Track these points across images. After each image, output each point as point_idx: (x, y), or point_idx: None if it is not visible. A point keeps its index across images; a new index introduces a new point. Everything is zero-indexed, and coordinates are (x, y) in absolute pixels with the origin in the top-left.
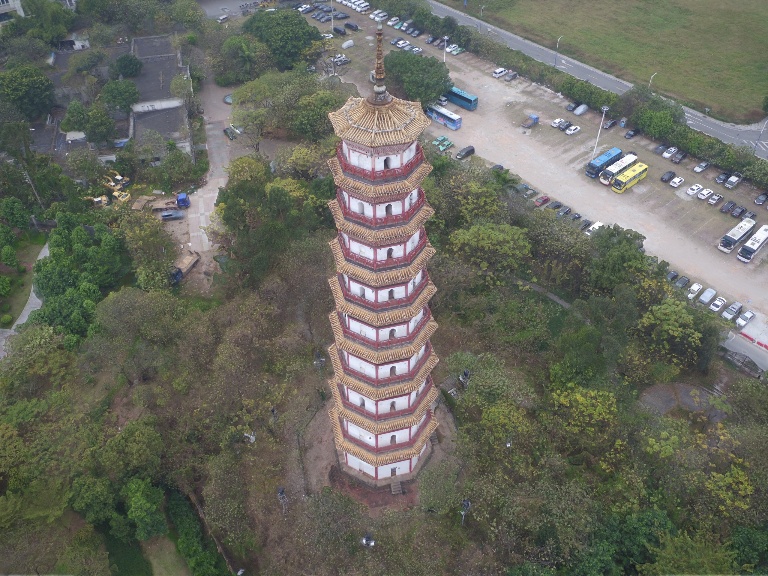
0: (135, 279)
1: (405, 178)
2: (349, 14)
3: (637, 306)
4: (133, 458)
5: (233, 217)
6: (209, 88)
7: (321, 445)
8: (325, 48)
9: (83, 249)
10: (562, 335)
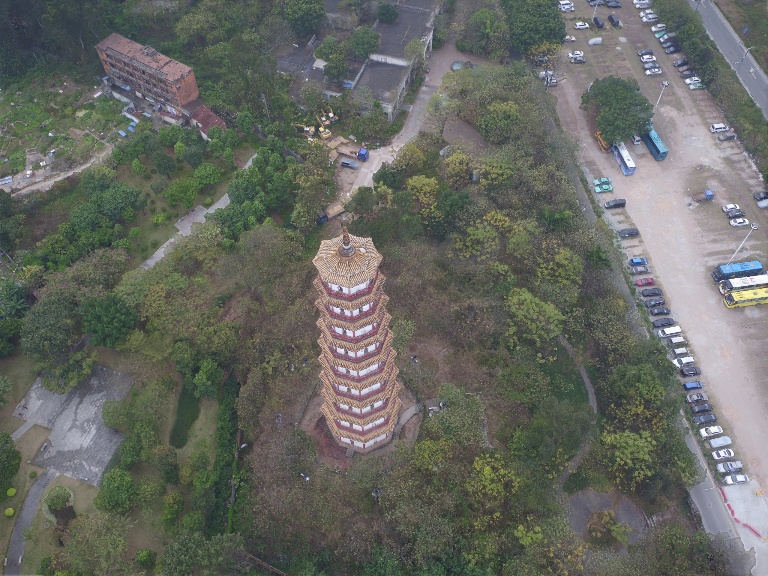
0: None
1: (350, 301)
2: (623, 3)
3: (619, 423)
4: (214, 346)
5: (349, 211)
6: (448, 48)
7: None
8: (547, 55)
9: (272, 172)
10: None
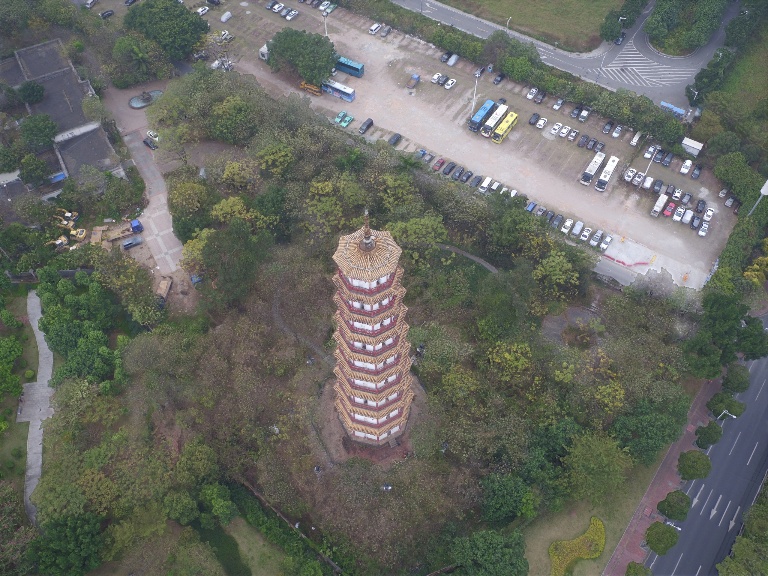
0: (128, 314)
1: (390, 287)
2: None
3: (531, 260)
4: (200, 471)
5: None
6: (110, 93)
7: (330, 424)
8: (217, 44)
9: (74, 299)
10: (481, 293)
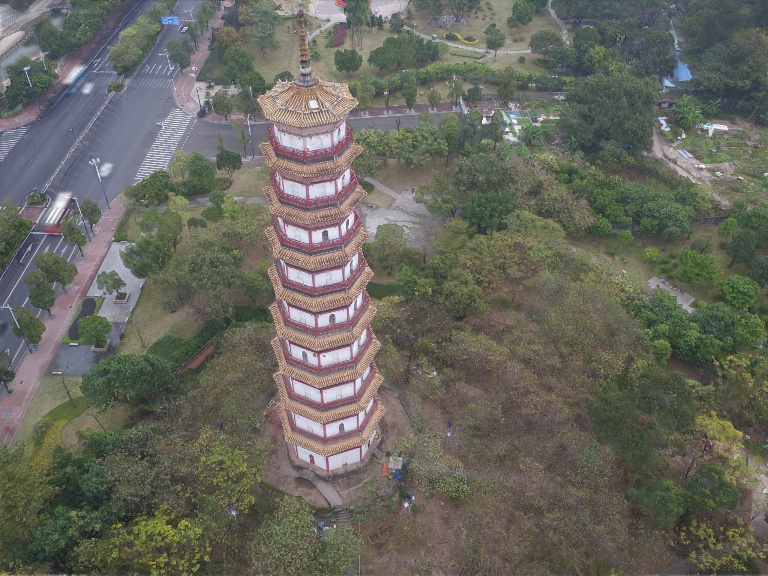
0: None
1: None
2: None
3: None
4: None
5: None
6: None
7: None
8: None
9: (766, 354)
10: None
